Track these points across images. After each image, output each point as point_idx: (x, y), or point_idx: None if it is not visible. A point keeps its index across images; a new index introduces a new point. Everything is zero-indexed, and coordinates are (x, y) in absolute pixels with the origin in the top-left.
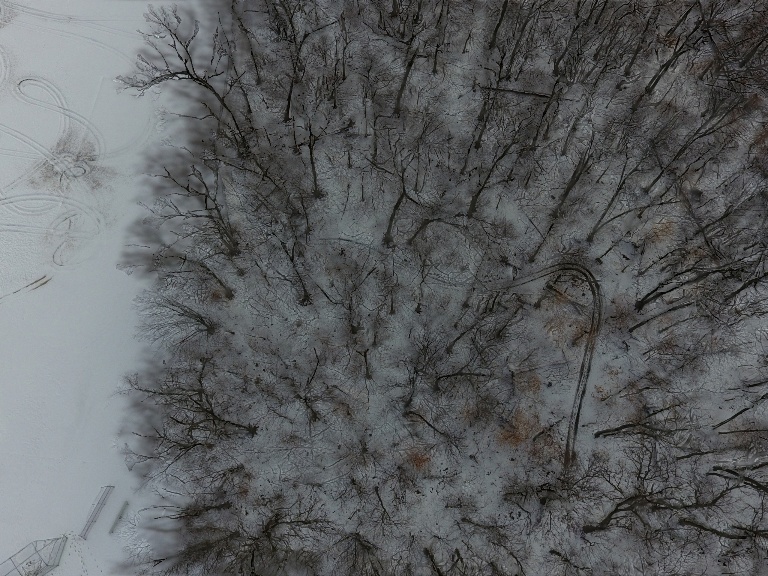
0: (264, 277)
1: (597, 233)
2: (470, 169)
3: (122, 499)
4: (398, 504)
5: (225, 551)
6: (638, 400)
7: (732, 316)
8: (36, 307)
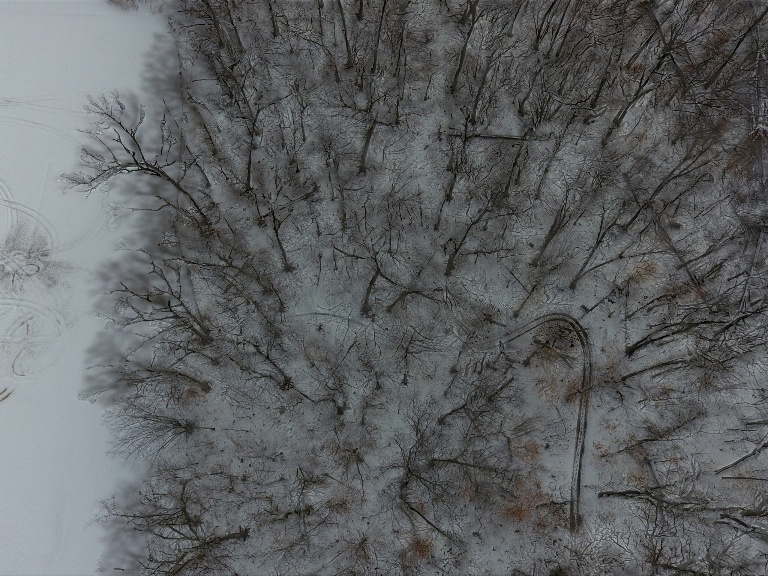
0: None
1: (580, 280)
2: (444, 225)
3: None
4: None
5: None
6: (638, 452)
7: (723, 352)
8: None
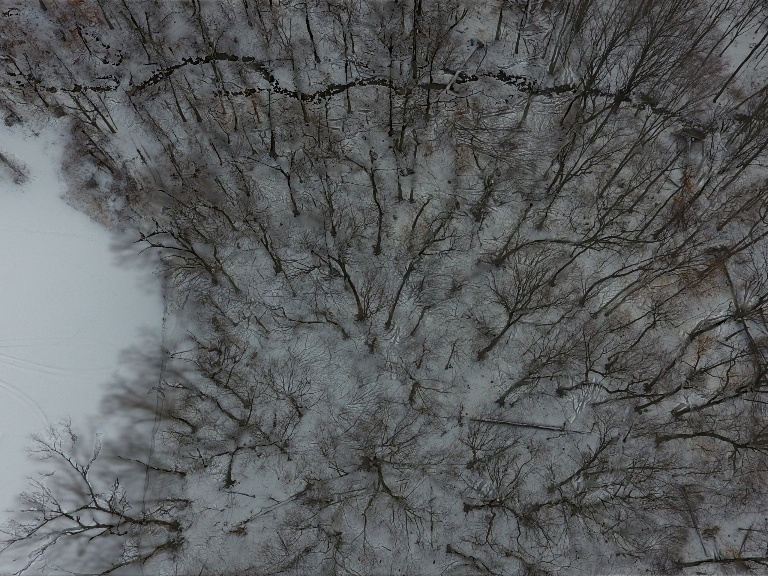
0: None
1: None
2: (458, 551)
3: None
4: None
5: None
6: None
7: None
8: None
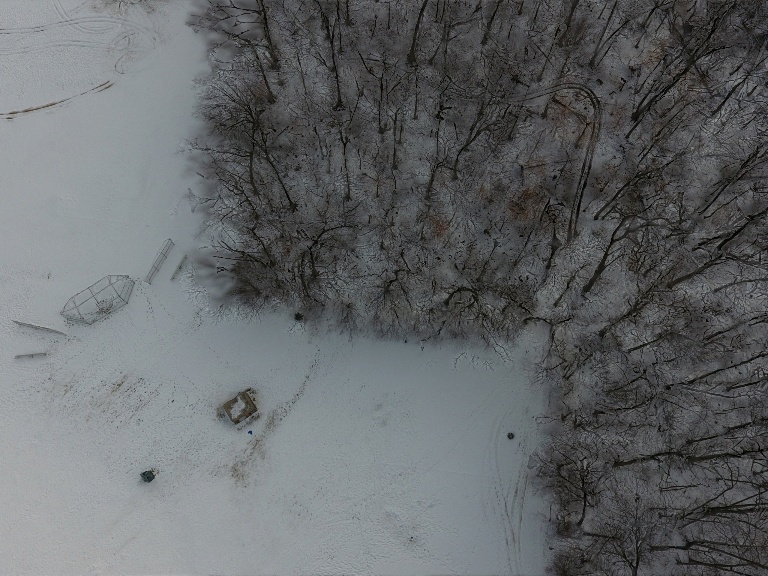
0: (303, 81)
1: (598, 56)
2: (485, 4)
3: (181, 254)
4: (421, 267)
5: (271, 297)
6: (633, 191)
7: (718, 127)
8: (101, 105)
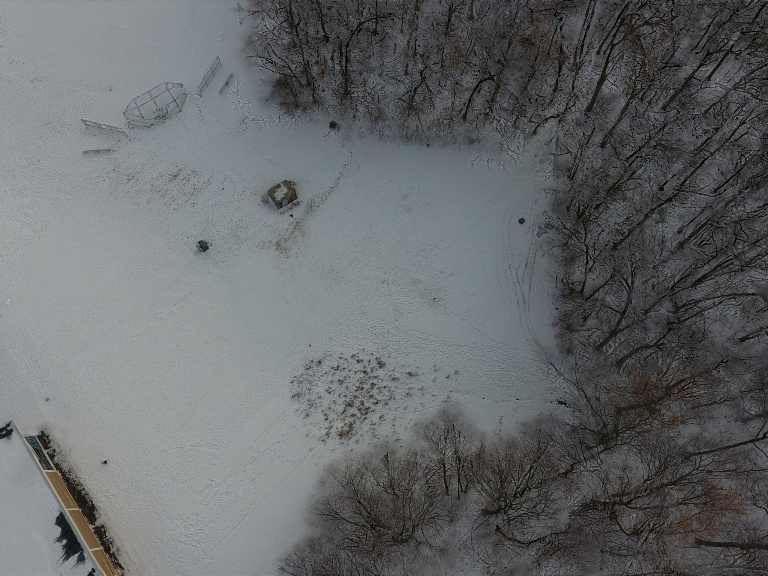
0: None
1: None
2: None
3: (228, 73)
4: (441, 90)
5: (308, 109)
6: None
7: None
8: None
